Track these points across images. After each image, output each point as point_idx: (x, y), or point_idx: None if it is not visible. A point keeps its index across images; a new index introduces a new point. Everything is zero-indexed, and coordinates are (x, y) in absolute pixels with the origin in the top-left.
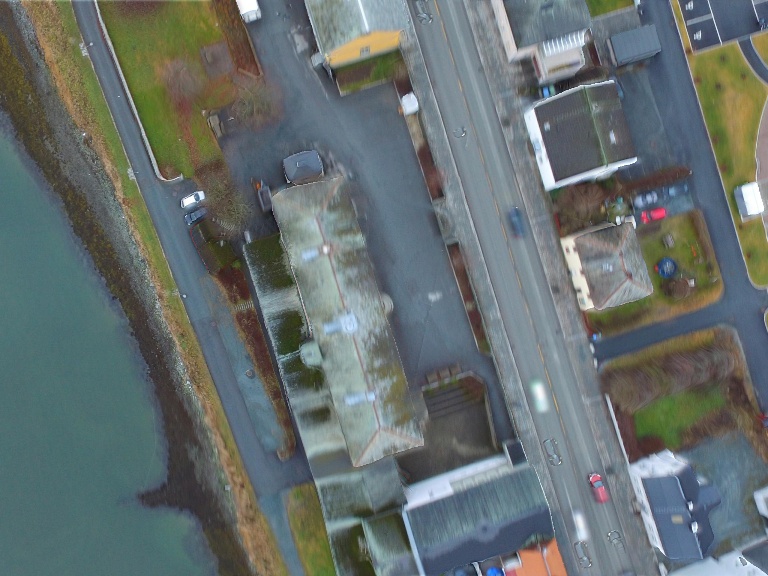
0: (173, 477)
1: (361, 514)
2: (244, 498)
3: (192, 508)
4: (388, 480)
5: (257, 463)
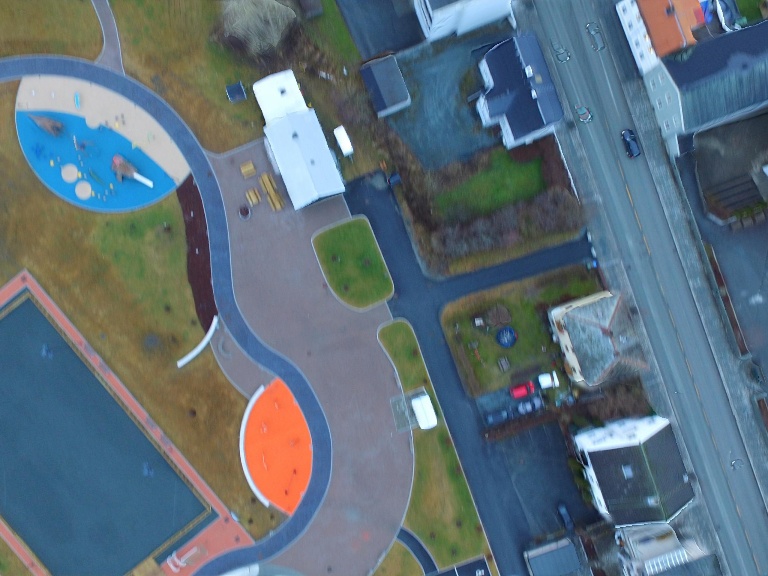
0: None
1: None
2: None
3: None
4: None
5: None
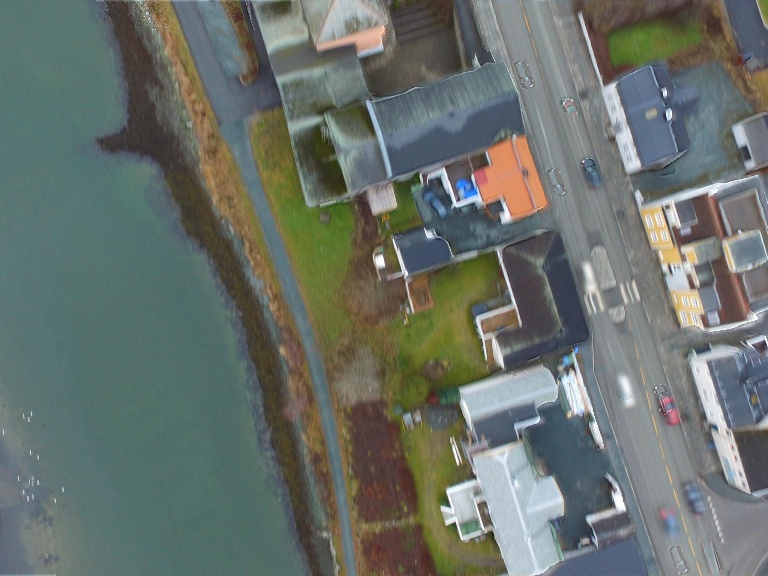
0: (133, 119)
1: (324, 110)
2: (206, 127)
3: (153, 153)
4: (352, 78)
5: (218, 87)
